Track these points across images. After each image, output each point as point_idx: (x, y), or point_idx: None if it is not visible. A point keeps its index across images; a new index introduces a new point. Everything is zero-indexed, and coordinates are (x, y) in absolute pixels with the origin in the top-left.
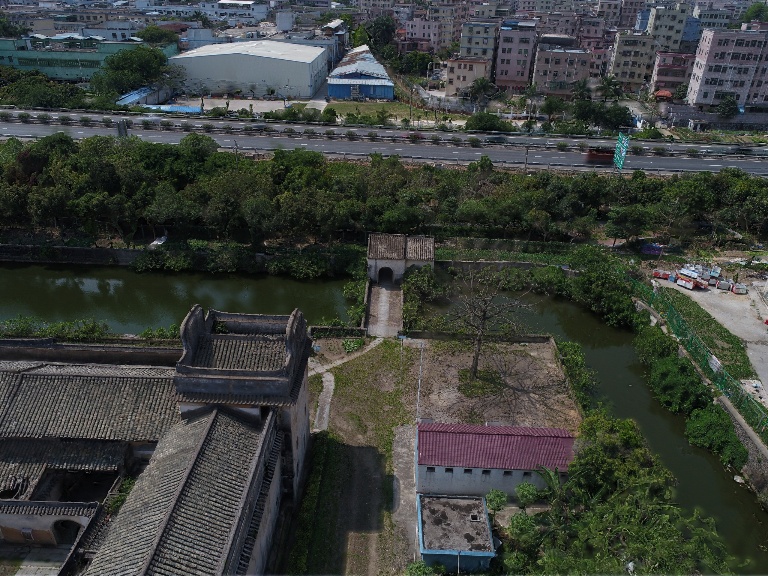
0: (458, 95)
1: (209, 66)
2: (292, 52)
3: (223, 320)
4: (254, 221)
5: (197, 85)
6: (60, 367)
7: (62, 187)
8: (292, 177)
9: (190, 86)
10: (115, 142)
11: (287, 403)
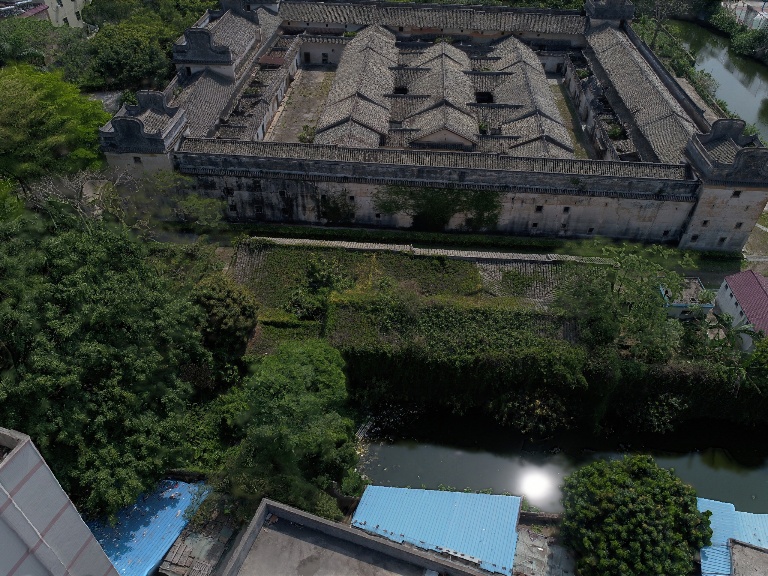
0: None
1: None
2: None
3: (755, 144)
4: None
5: None
6: (693, 127)
7: None
8: None
9: None
10: None
11: (703, 181)
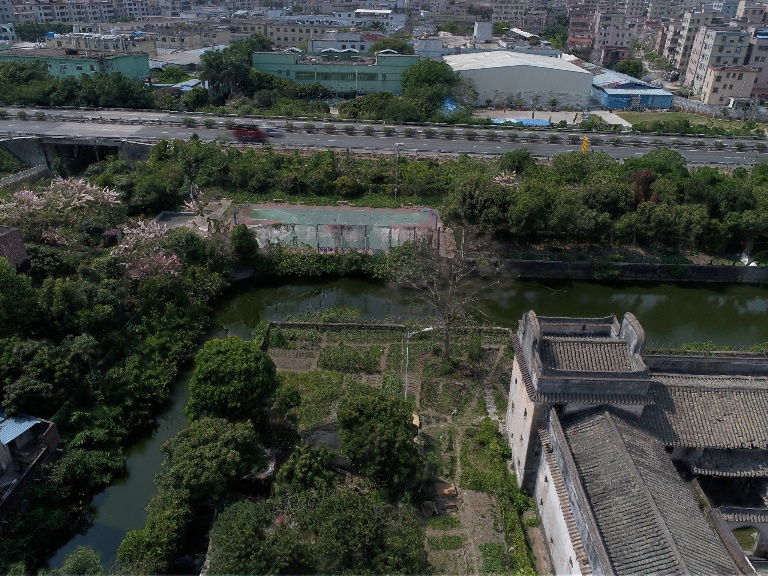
0: None
1: (492, 78)
2: (553, 63)
3: None
4: None
5: (534, 98)
6: None
7: (704, 206)
8: None
9: (523, 99)
10: (596, 158)
11: None
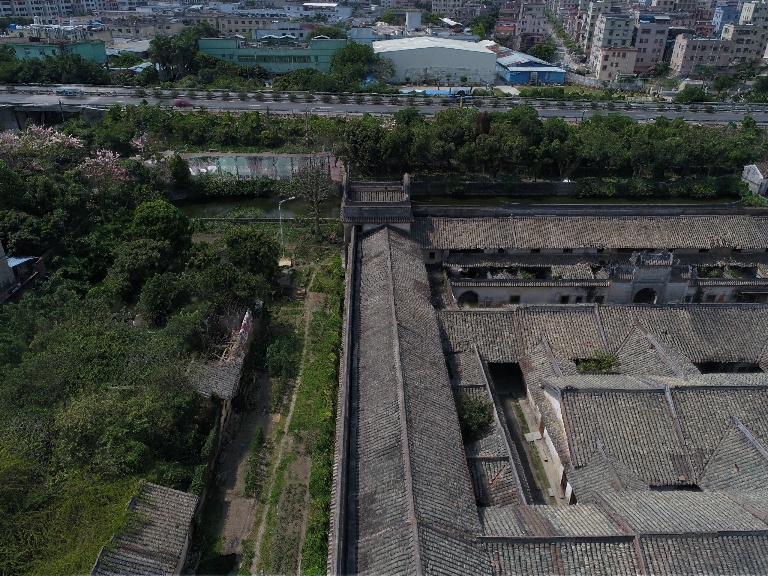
0: (640, 77)
1: (410, 58)
2: None
3: None
4: (668, 157)
5: (438, 72)
6: None
7: (524, 137)
8: (628, 133)
9: (429, 74)
10: (467, 112)
11: None
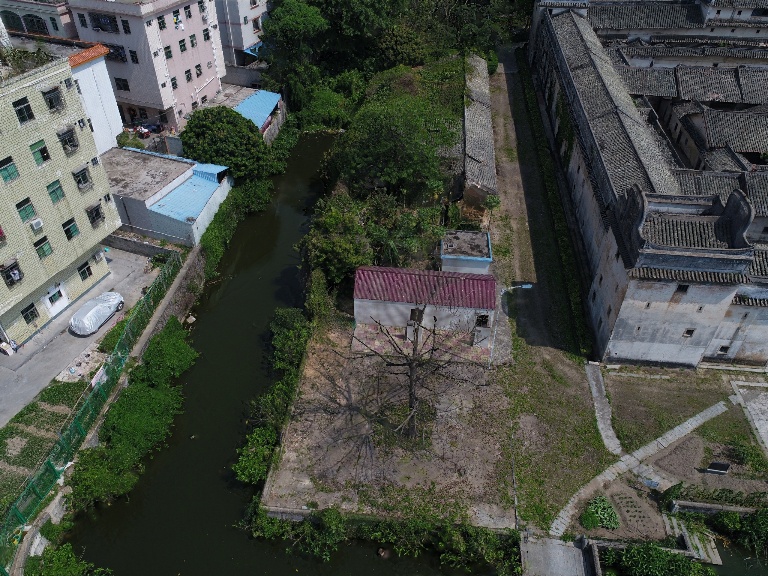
0: None
1: None
2: None
3: None
4: None
5: None
6: None
7: None
8: None
9: None
10: None
11: None
